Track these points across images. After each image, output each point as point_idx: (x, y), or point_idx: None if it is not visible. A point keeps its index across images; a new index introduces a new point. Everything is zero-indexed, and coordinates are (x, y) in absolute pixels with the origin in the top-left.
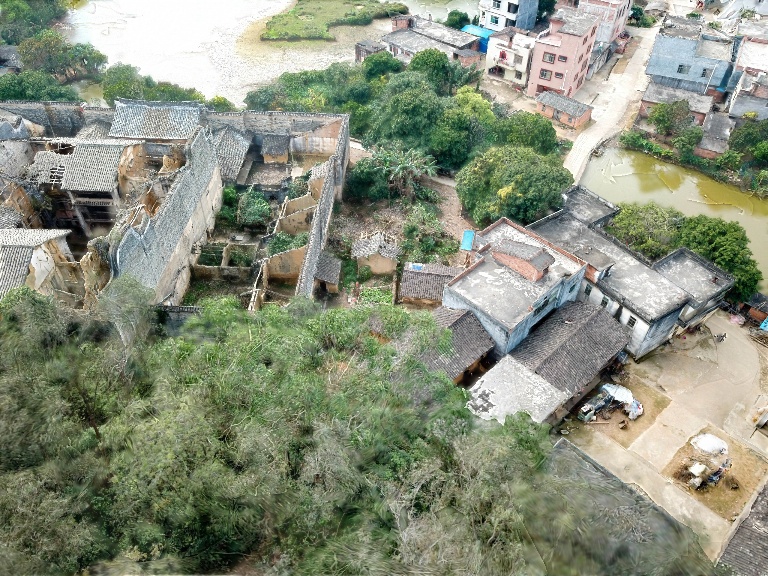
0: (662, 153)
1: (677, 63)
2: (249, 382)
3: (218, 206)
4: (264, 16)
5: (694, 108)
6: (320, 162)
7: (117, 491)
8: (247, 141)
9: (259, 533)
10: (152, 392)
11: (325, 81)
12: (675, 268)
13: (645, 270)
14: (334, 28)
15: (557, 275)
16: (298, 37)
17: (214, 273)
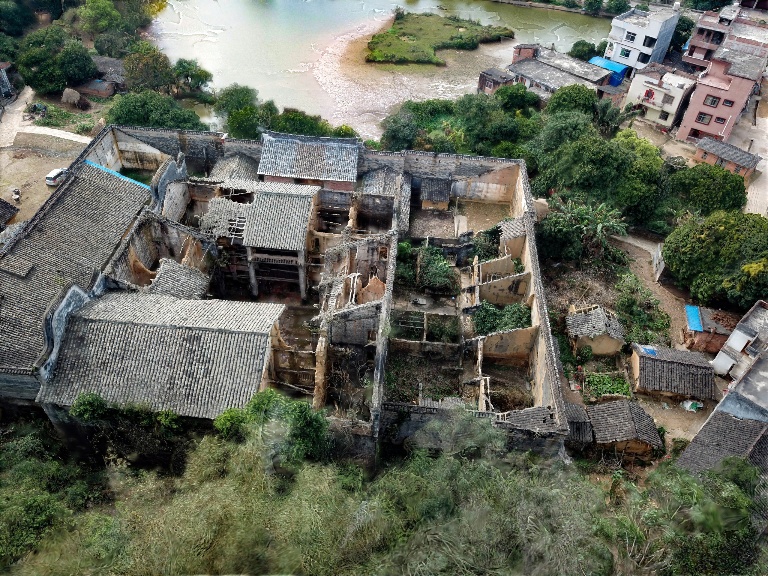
0: None
1: None
2: None
3: None
4: (362, 35)
5: None
6: None
7: None
8: (407, 184)
9: None
10: None
11: (459, 114)
12: None
13: None
14: (440, 52)
15: None
16: (406, 60)
17: (413, 348)
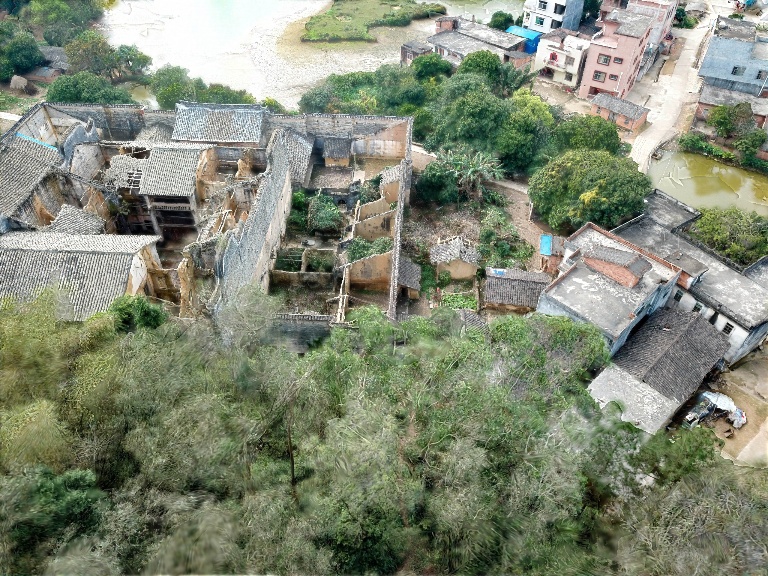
0: (723, 156)
1: (732, 65)
2: (449, 400)
3: (288, 210)
4: (301, 17)
5: (753, 110)
6: (382, 165)
7: (328, 513)
8: (309, 144)
9: (500, 559)
10: (350, 410)
11: (375, 83)
12: (765, 274)
13: (735, 276)
14: (373, 29)
15: (652, 281)
16: (339, 38)
17: (293, 279)
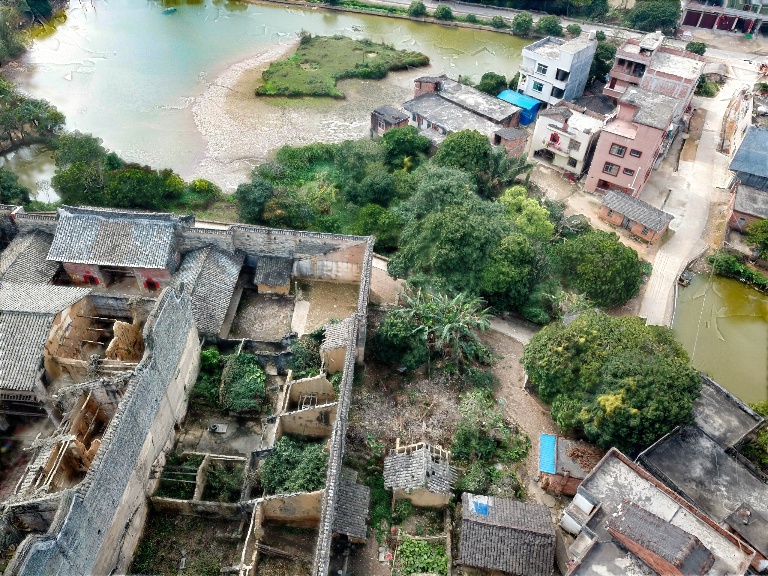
0: (766, 286)
1: None
2: None
3: (193, 378)
4: (260, 62)
5: None
6: (333, 296)
7: None
8: (236, 266)
9: None
10: None
11: (336, 164)
12: None
13: None
14: (343, 82)
15: (712, 573)
16: (300, 93)
17: (182, 507)
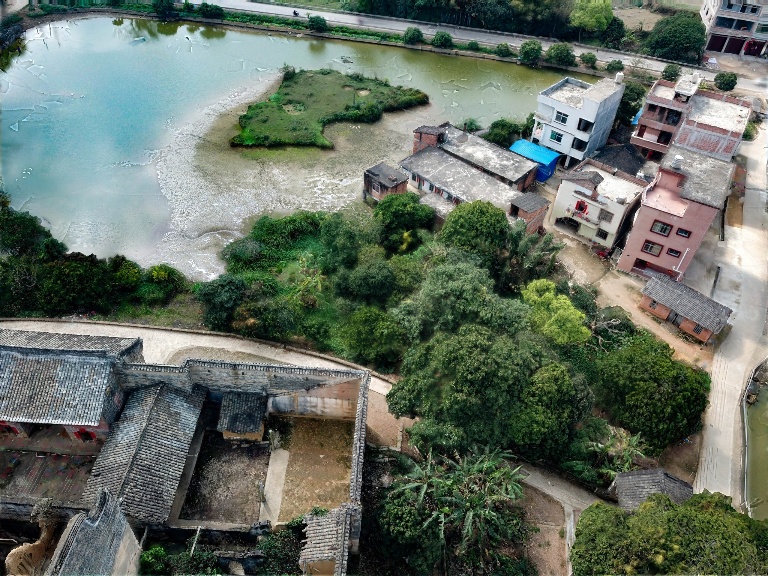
0: None
1: None
2: None
3: None
4: (237, 103)
5: None
6: None
7: None
8: (194, 411)
9: None
10: None
11: (322, 243)
12: None
13: None
14: (331, 127)
15: None
16: (282, 143)
17: None
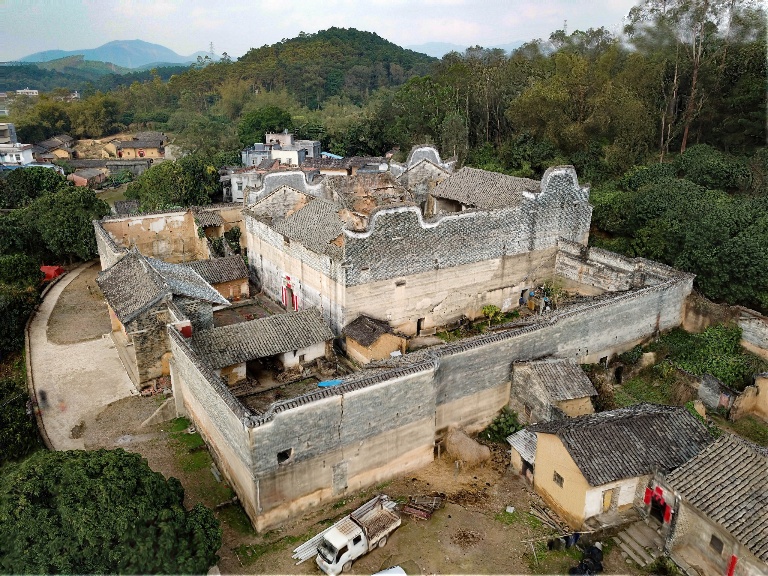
0: None
1: None
2: None
3: None
4: None
5: None
6: None
7: None
8: None
9: None
10: None
11: None
12: None
13: None
14: None
15: None
16: None
17: None
